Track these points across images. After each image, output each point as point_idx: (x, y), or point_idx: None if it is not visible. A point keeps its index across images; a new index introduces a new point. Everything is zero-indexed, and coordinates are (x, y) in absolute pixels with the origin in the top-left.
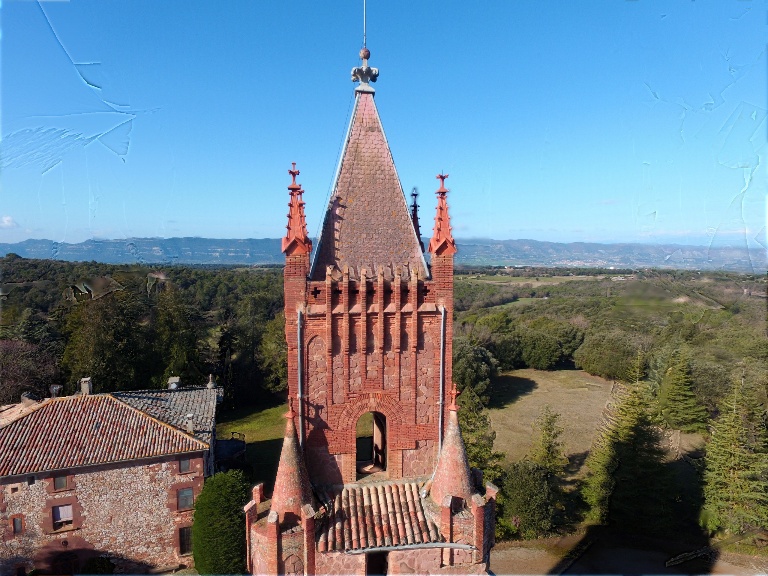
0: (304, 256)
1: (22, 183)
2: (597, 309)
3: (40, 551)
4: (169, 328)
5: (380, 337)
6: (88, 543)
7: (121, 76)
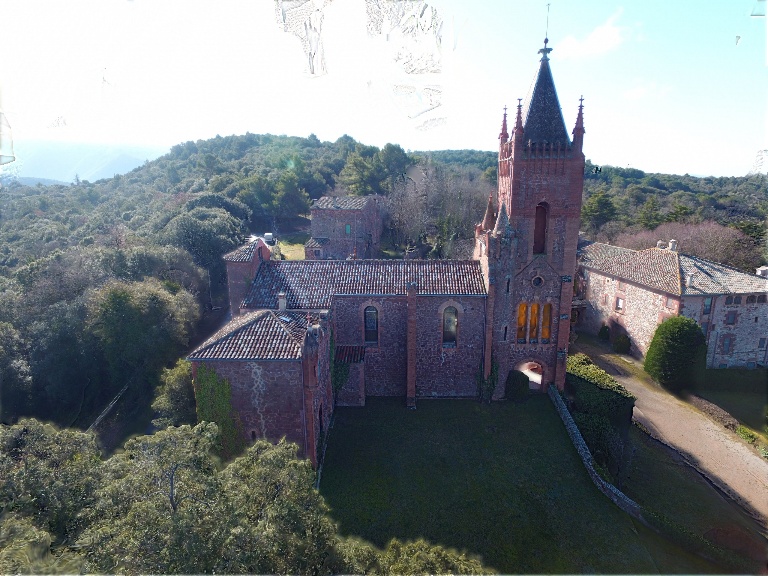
0: None
1: (447, 128)
2: None
3: (610, 318)
4: None
5: None
6: (625, 325)
7: None
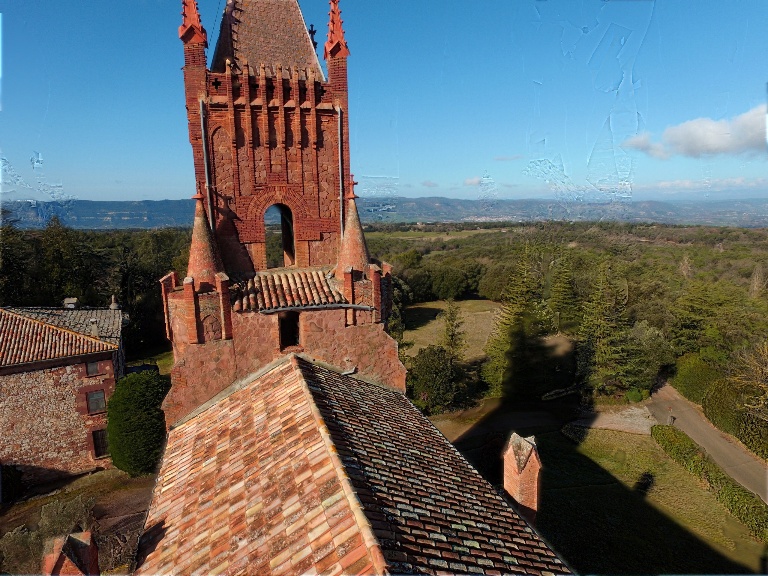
0: (202, 45)
1: None
2: (491, 208)
3: None
4: (59, 265)
5: (282, 131)
6: None
7: None
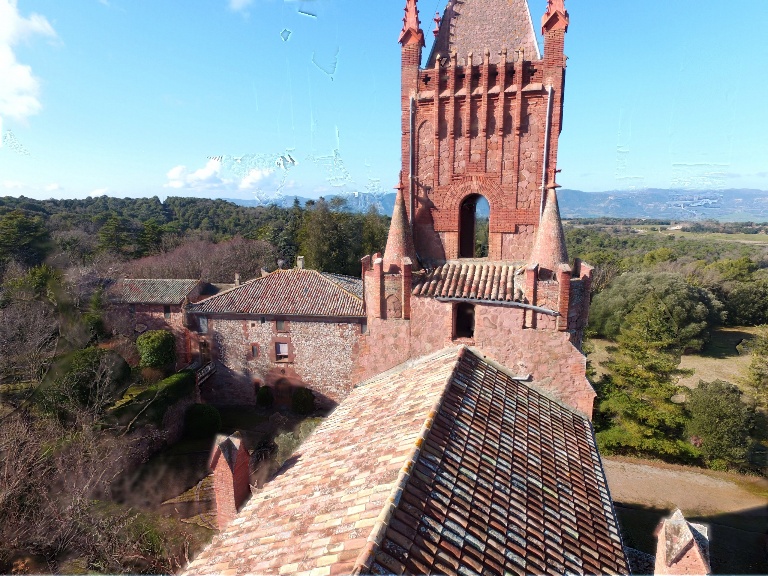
0: (417, 45)
1: None
2: None
3: (268, 373)
4: (371, 244)
5: (483, 119)
6: (297, 375)
7: (331, 2)
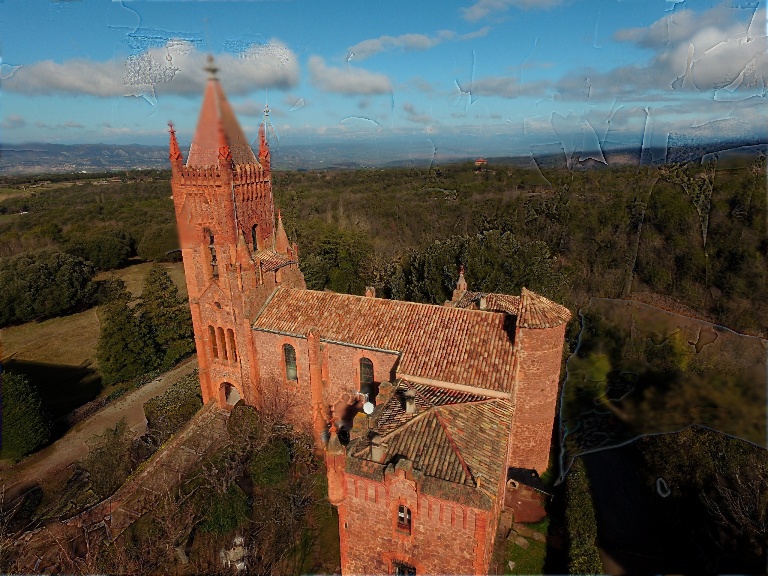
0: None
1: None
2: None
3: None
4: None
5: None
6: None
7: None
